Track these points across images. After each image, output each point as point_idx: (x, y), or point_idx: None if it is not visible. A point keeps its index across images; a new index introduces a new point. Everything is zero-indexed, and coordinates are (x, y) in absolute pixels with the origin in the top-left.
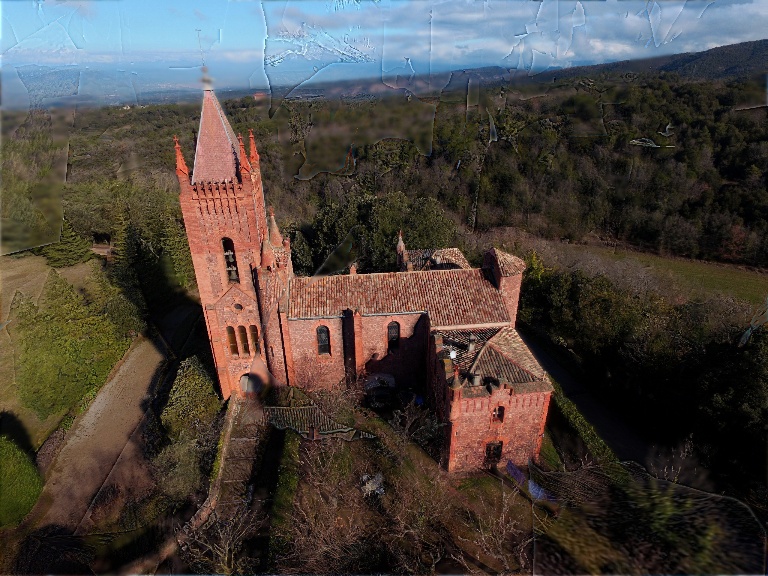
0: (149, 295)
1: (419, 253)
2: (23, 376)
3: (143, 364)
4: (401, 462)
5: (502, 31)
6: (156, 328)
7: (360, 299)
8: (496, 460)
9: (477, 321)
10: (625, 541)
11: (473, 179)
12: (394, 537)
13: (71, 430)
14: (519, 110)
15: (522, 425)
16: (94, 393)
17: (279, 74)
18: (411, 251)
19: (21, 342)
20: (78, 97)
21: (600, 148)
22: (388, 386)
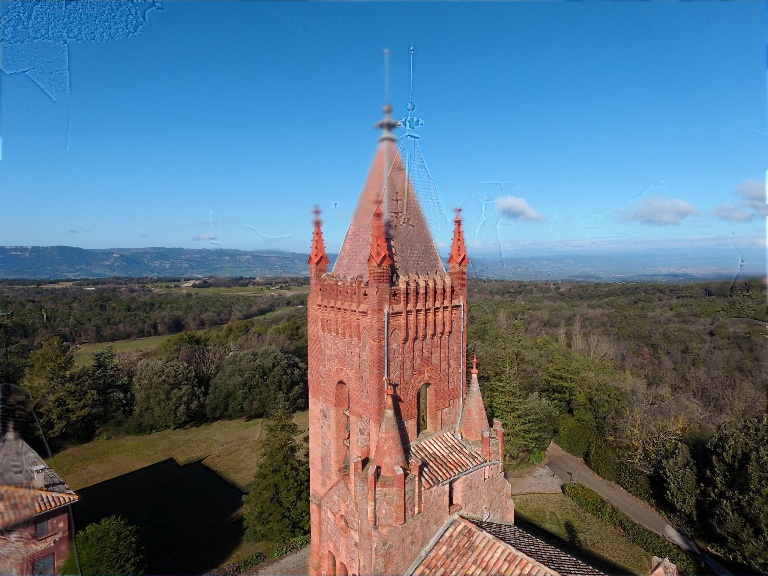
0: None
1: None
2: (250, 482)
3: None
4: None
5: None
6: None
7: None
8: None
9: None
10: None
11: None
12: None
13: (246, 573)
14: None
15: None
16: (303, 542)
17: None
18: None
19: (262, 445)
20: (484, 242)
21: None
22: None
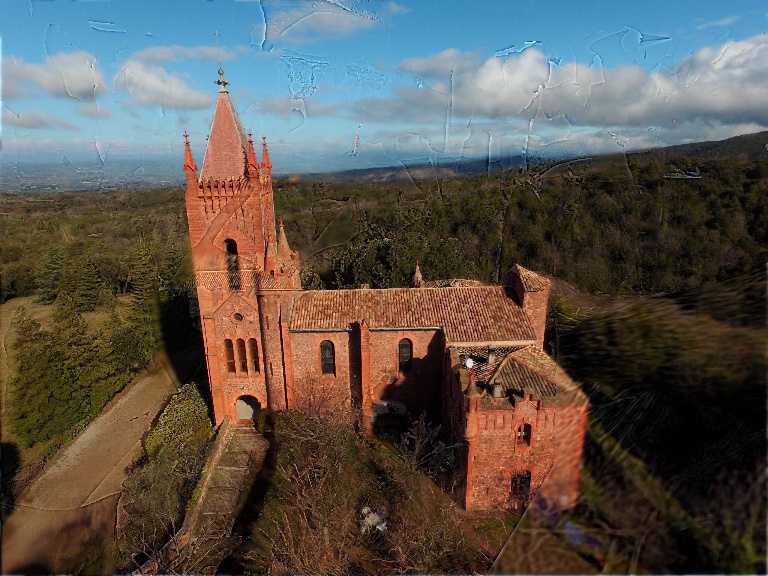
0: (160, 332)
1: (437, 282)
2: (12, 396)
3: (142, 398)
4: (409, 496)
5: (521, 88)
6: (163, 365)
7: (369, 313)
8: (523, 497)
9: (498, 338)
10: (725, 287)
11: (496, 234)
12: (392, 570)
13: (53, 459)
14: (540, 155)
15: (553, 451)
16: (85, 423)
17: (275, 7)
18: (429, 282)
19: (16, 359)
20: (118, 149)
21: (627, 193)
22: (398, 413)
